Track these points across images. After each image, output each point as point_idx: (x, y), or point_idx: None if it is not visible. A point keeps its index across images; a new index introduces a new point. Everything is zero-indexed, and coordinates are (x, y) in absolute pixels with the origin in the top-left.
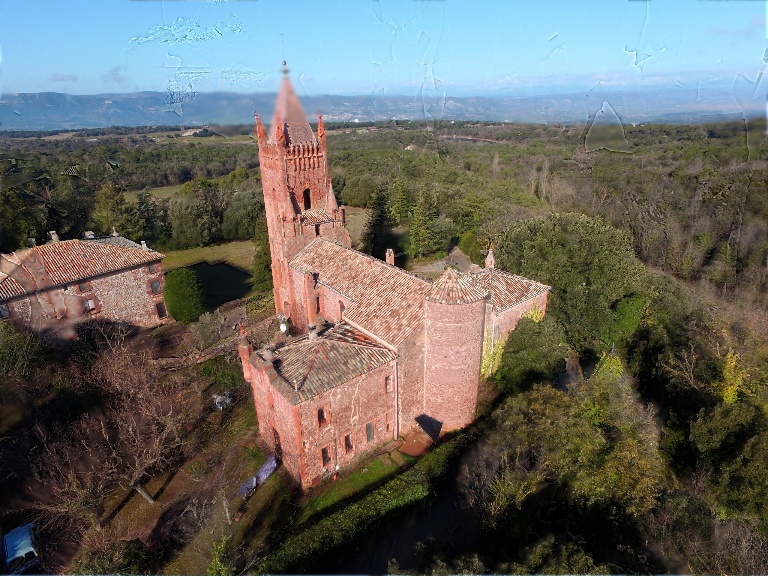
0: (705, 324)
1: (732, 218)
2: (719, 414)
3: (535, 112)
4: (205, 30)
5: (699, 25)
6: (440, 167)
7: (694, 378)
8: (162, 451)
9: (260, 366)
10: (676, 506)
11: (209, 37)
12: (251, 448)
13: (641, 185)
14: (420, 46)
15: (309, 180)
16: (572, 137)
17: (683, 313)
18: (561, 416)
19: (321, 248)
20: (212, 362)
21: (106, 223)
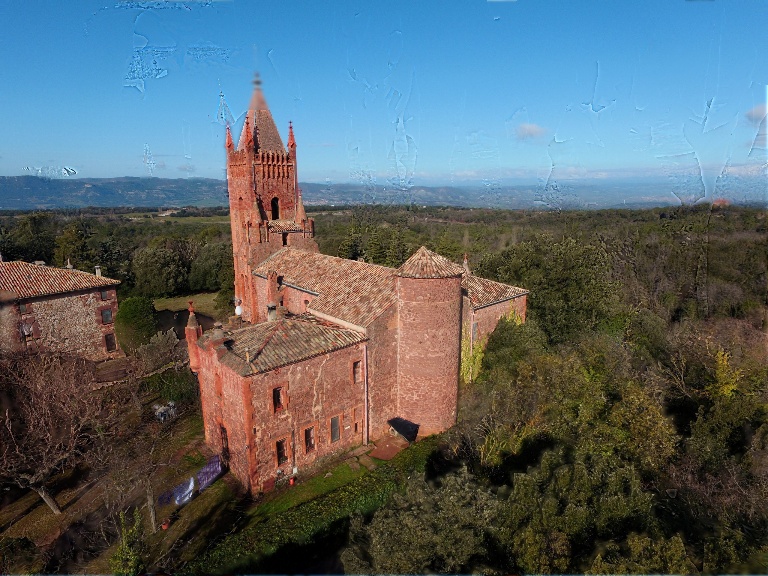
0: (688, 336)
1: (697, 253)
2: (720, 408)
3: (502, 165)
4: (174, 5)
5: (646, 72)
6: (412, 214)
7: (686, 386)
8: (78, 443)
9: (208, 343)
10: (699, 448)
11: (177, 7)
12: (193, 456)
13: (607, 231)
14: (392, 106)
15: (278, 189)
16: (538, 189)
17: (663, 338)
18: (554, 369)
19: (288, 255)
20: (158, 376)
21: None
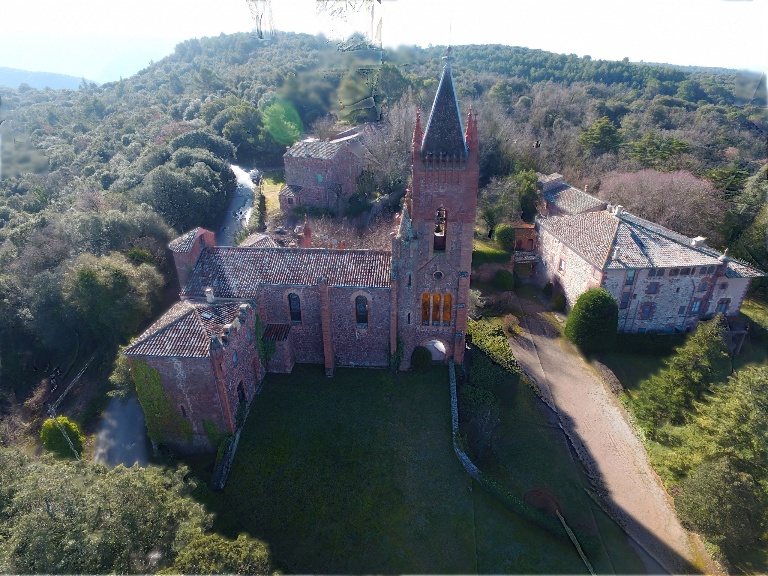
0: None
1: None
2: None
3: None
4: None
5: None
6: None
7: None
8: None
9: None
10: None
11: None
12: None
13: None
14: None
15: None
16: None
17: None
18: None
19: None
20: None
21: None
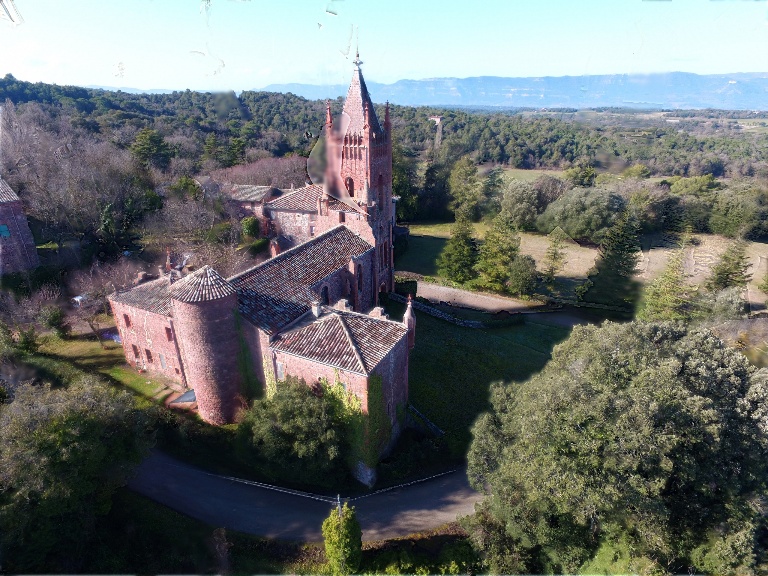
0: None
1: None
2: None
3: None
4: None
5: None
6: None
7: None
8: None
9: None
10: None
11: None
12: None
13: None
14: None
15: (351, 169)
16: None
17: None
18: None
19: None
20: None
21: (453, 187)
